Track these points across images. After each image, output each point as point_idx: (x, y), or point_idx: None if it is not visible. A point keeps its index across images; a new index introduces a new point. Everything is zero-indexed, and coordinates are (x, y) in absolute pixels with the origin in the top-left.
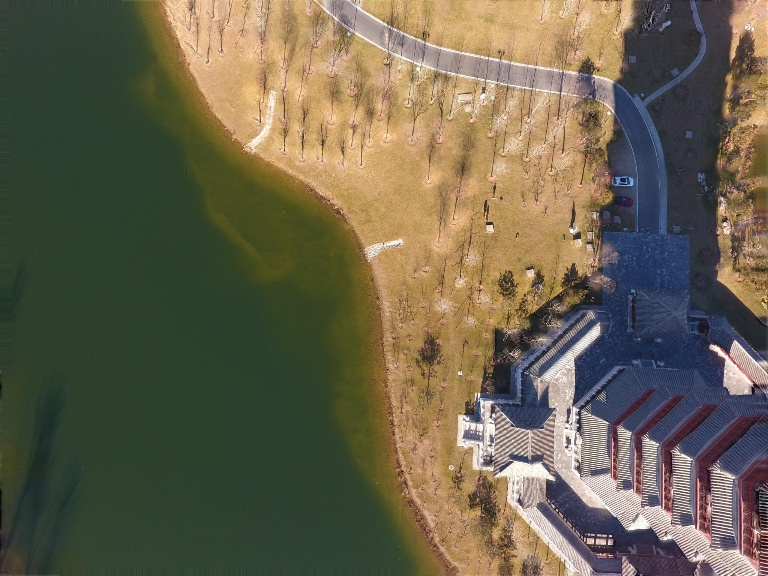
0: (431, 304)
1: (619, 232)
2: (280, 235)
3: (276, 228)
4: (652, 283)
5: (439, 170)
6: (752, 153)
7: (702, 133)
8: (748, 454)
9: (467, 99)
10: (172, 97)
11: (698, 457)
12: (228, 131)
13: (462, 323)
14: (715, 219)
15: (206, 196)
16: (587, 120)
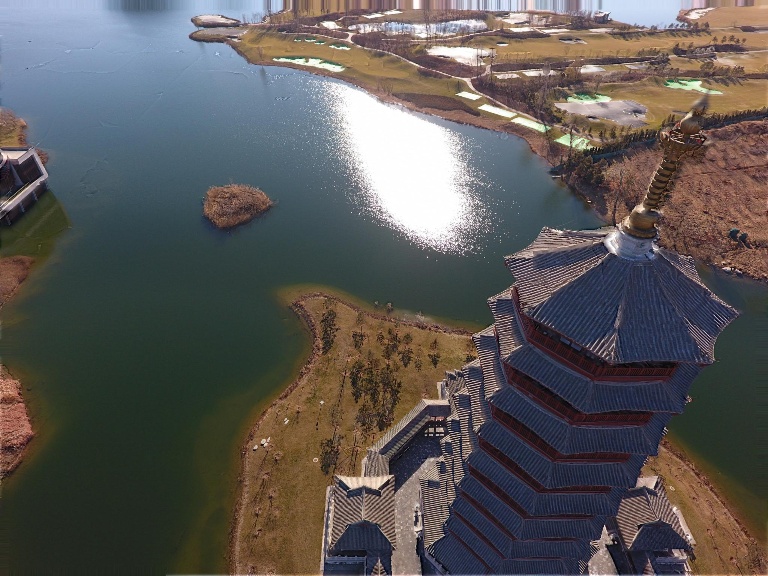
0: None
1: None
2: None
3: None
4: None
5: None
6: None
7: None
8: None
9: None
10: None
11: None
12: None
13: None
14: None
15: None
16: None
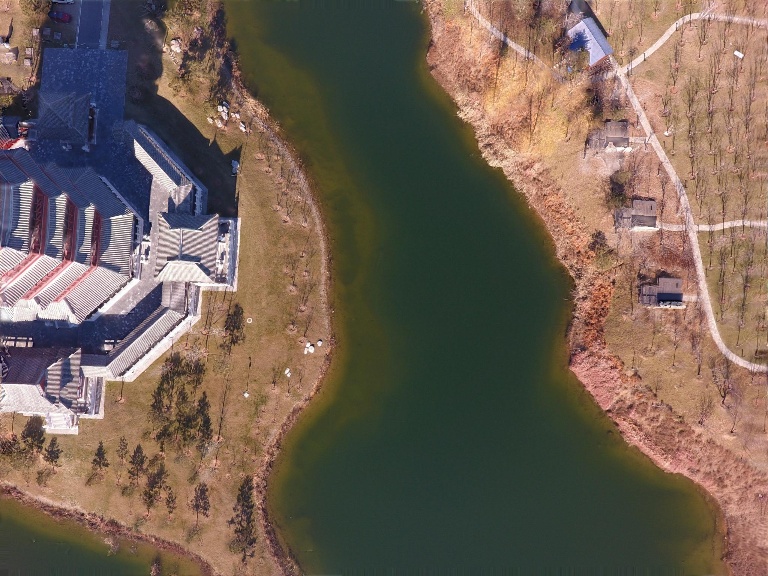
0: None
1: (59, 48)
2: None
3: None
4: None
5: None
6: None
7: None
8: None
9: None
10: None
11: None
12: None
13: None
14: (163, 37)
15: None
16: None
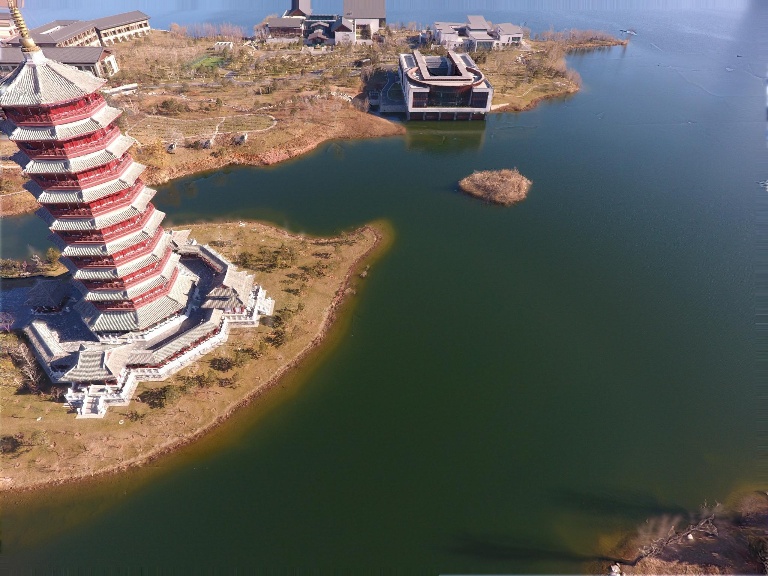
0: None
1: None
2: None
3: None
4: None
5: None
6: None
7: None
8: (51, 218)
9: None
10: None
11: None
12: None
13: None
14: (14, 278)
15: None
16: None
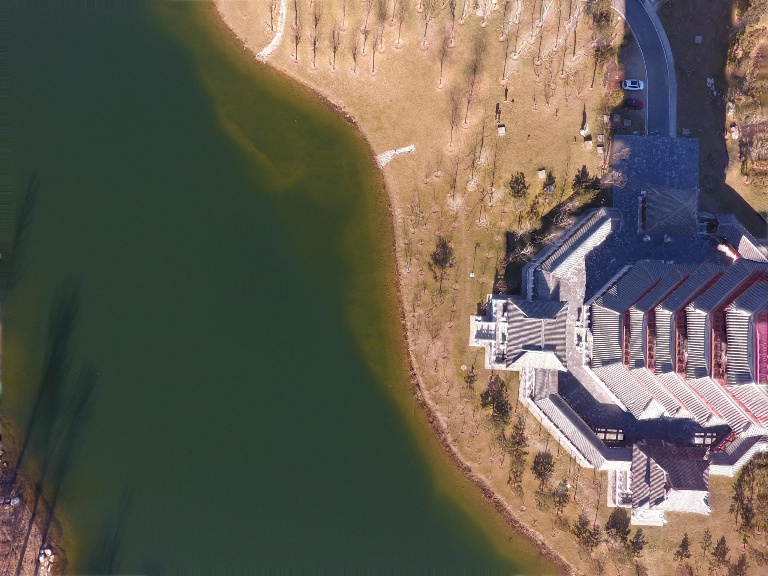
0: (443, 208)
1: (629, 135)
2: (292, 144)
3: (288, 137)
4: (662, 185)
5: (451, 74)
6: (760, 62)
7: (711, 38)
8: (763, 294)
9: (479, 3)
10: (183, 7)
11: (713, 310)
12: (239, 40)
13: (474, 226)
14: (723, 124)
15: (218, 105)
16: (598, 20)
